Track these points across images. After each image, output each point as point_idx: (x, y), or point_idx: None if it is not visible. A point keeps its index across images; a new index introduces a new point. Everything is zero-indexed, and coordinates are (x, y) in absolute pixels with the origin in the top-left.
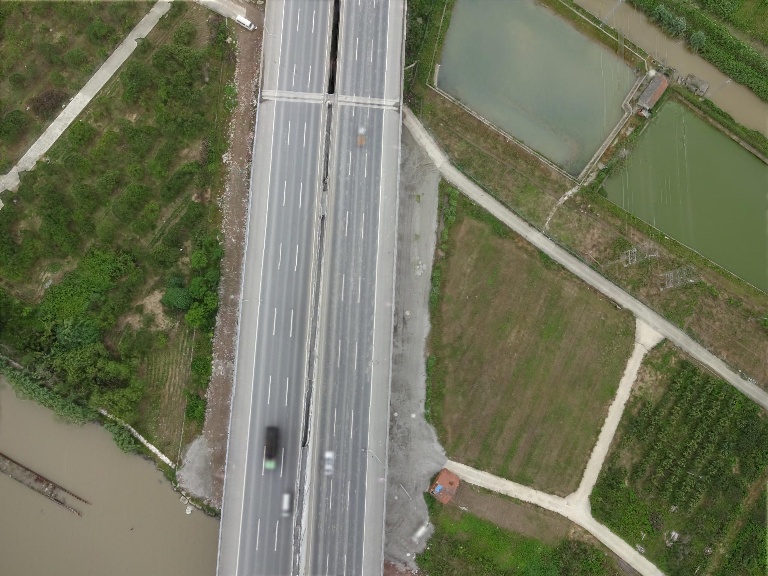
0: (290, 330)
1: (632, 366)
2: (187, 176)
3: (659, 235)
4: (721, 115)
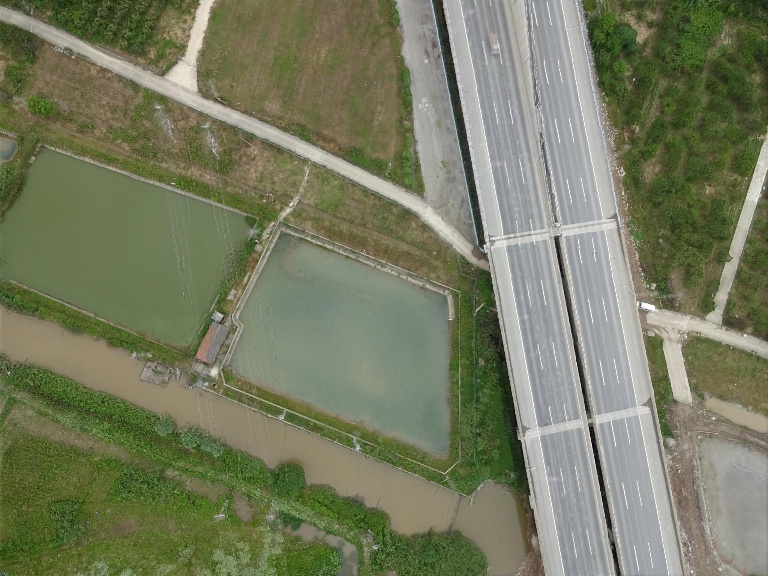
0: (535, 8)
1: (197, 42)
2: (651, 141)
3: (183, 183)
4: (123, 341)
